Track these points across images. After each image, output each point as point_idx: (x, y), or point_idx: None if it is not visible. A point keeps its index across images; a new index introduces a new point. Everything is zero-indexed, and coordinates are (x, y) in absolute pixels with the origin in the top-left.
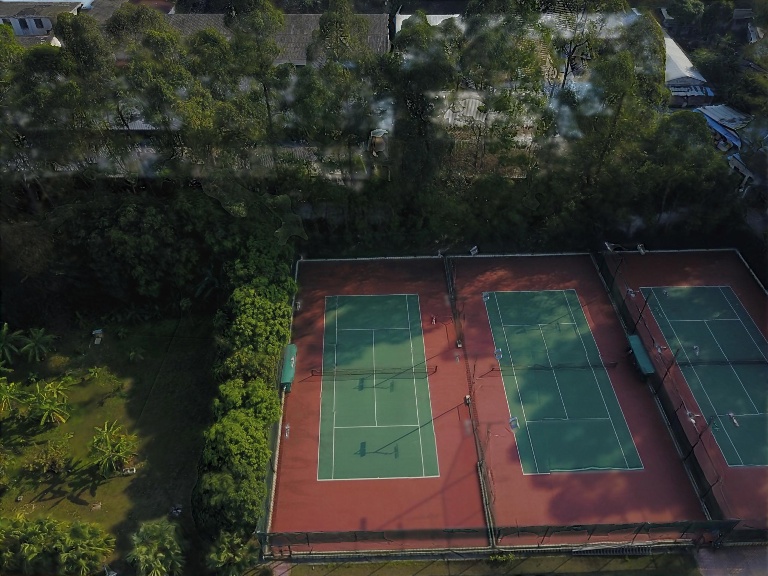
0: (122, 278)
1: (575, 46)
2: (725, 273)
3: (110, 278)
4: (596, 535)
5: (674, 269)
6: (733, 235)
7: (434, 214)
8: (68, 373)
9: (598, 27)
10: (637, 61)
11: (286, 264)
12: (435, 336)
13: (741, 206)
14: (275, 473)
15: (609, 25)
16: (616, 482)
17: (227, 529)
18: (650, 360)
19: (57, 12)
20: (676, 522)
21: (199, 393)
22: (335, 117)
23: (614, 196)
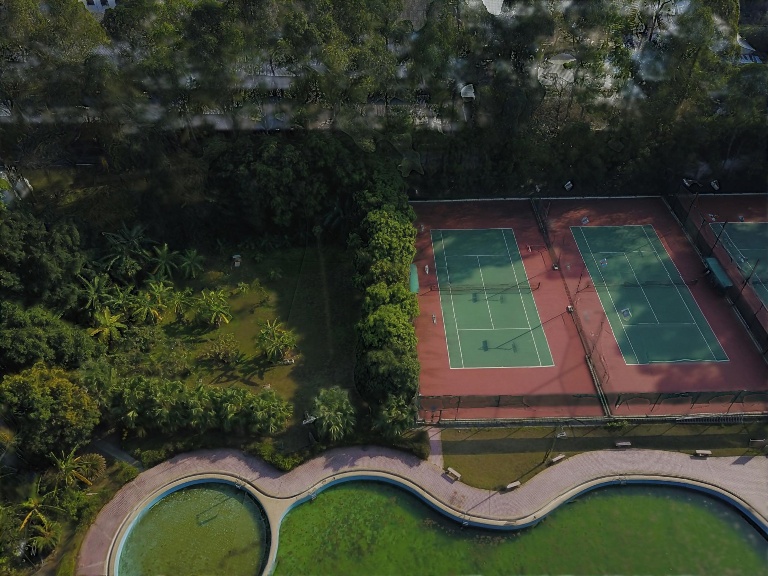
0: (262, 208)
1: (663, 3)
2: None
3: (253, 207)
4: (699, 403)
5: (739, 208)
6: None
7: (524, 159)
8: (219, 288)
9: None
10: (716, 17)
11: None
12: (533, 261)
13: None
14: None
15: None
16: (707, 370)
17: (393, 393)
18: (728, 276)
19: None
20: (767, 390)
21: (335, 304)
22: (450, 66)
23: (686, 142)
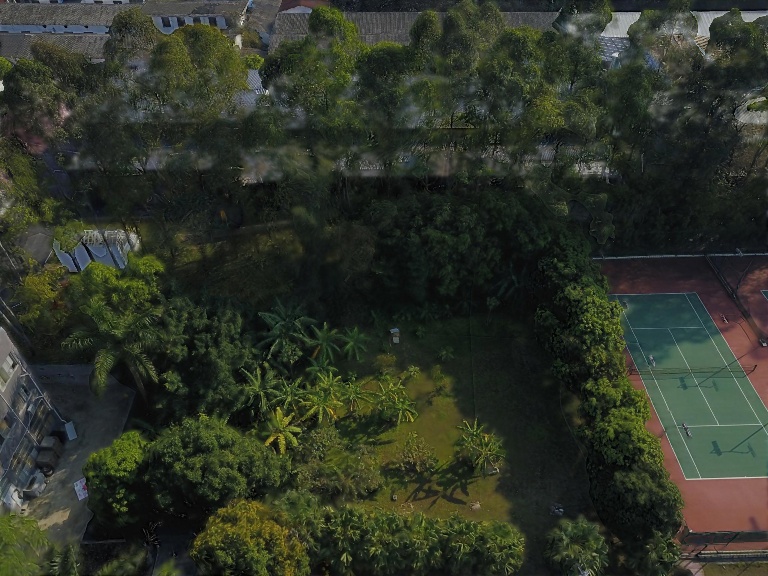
0: (428, 277)
1: None
2: None
3: (421, 277)
4: None
5: None
6: None
7: (703, 213)
8: (385, 372)
9: None
10: None
11: None
12: (734, 335)
13: None
14: None
15: None
16: None
17: (657, 528)
18: None
19: (231, 11)
20: None
21: (523, 392)
22: None
23: None
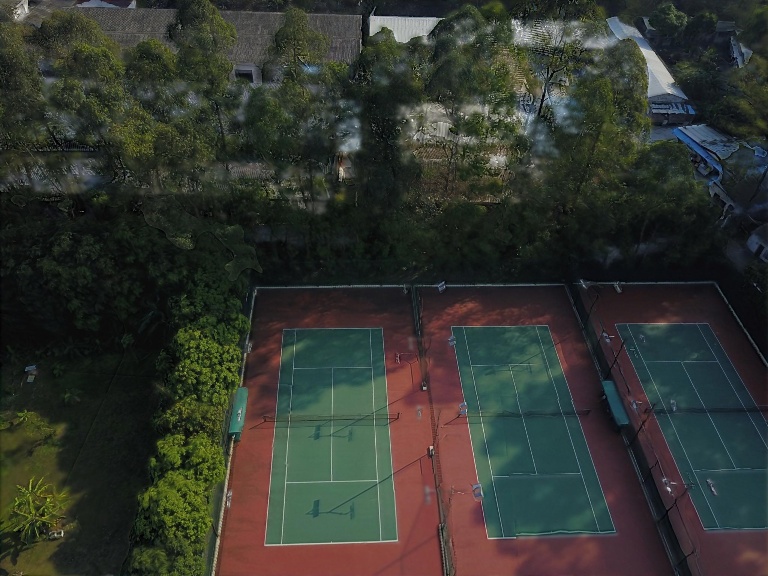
0: (57, 312)
1: (553, 72)
2: (703, 309)
3: (43, 312)
4: None
5: (651, 304)
6: (712, 268)
7: (401, 241)
8: None
9: (577, 52)
10: (618, 89)
11: (238, 299)
12: (399, 377)
13: (721, 239)
14: (218, 537)
15: (589, 50)
16: (586, 548)
17: None
18: (624, 409)
19: (5, 3)
20: None
21: (140, 441)
22: (293, 141)
23: (591, 226)
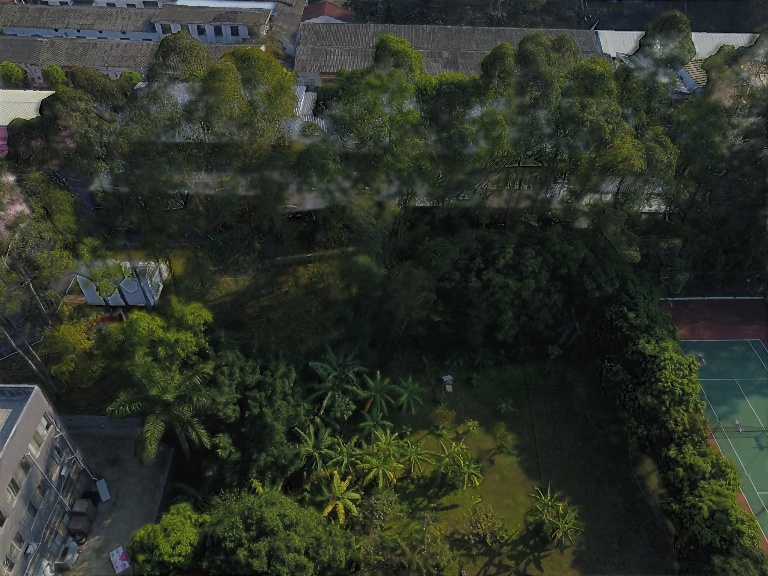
0: (487, 323)
1: None
2: None
3: None
4: None
5: None
6: None
7: (766, 254)
8: (441, 426)
9: None
10: None
11: None
12: None
13: None
14: None
15: None
16: None
17: None
18: None
19: (254, 19)
20: None
21: (590, 451)
22: None
23: None
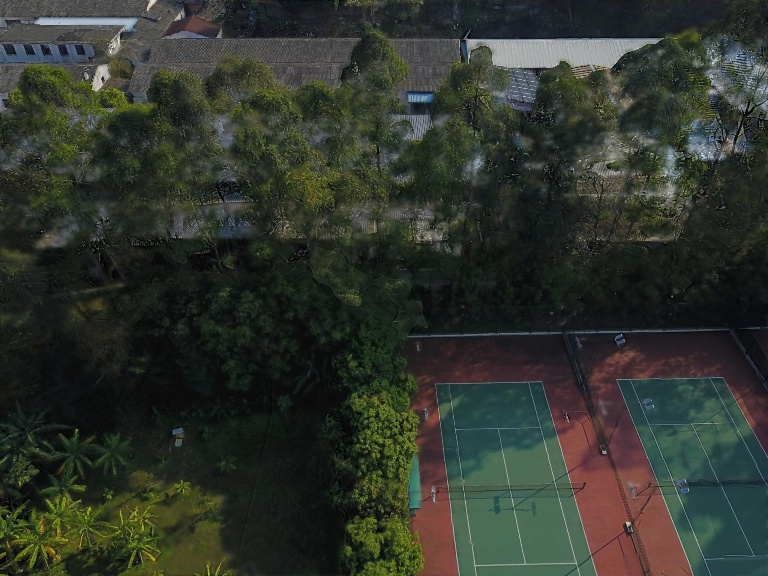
0: (210, 372)
1: (754, 106)
2: None
3: (197, 374)
4: None
5: None
6: None
7: (556, 287)
8: (149, 488)
9: None
10: None
11: None
12: (572, 438)
13: None
14: None
15: None
16: None
17: None
18: None
19: (100, 37)
20: None
21: (306, 515)
22: (463, 186)
23: (766, 268)
